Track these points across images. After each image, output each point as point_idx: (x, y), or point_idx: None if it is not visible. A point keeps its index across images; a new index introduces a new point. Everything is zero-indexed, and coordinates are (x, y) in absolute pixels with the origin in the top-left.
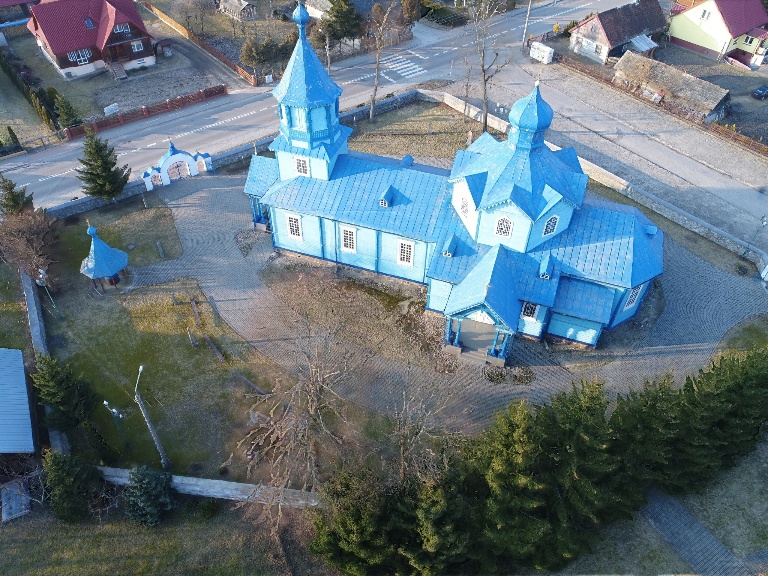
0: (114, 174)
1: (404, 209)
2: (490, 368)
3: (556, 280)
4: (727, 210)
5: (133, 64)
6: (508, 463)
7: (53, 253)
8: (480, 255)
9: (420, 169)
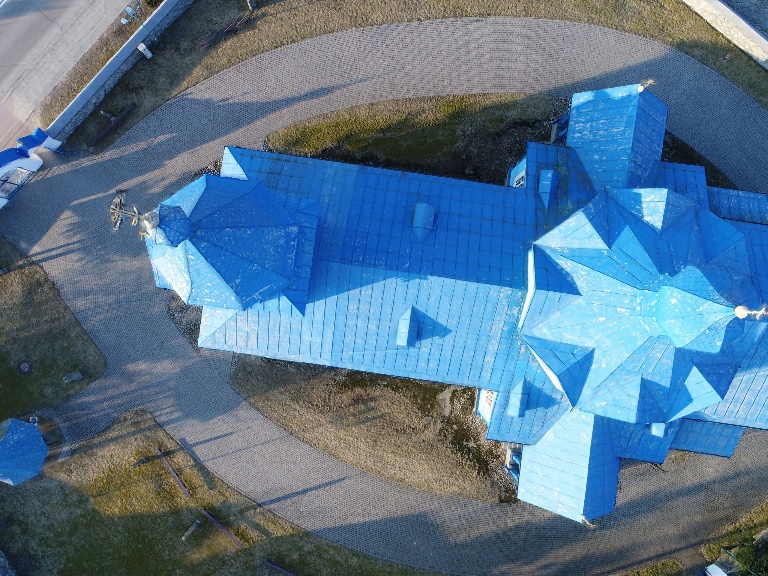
0: None
1: (440, 344)
2: None
3: (673, 431)
4: None
5: None
6: None
7: None
8: (564, 406)
9: (454, 248)
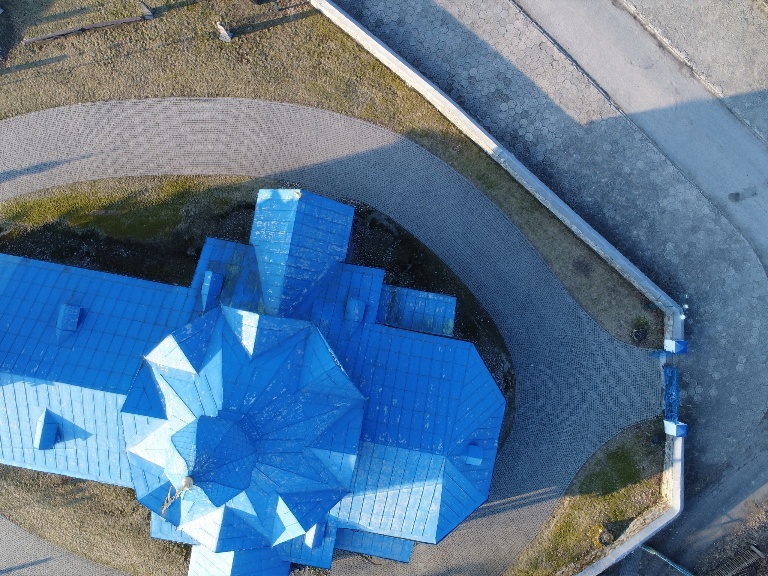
0: None
1: (84, 446)
2: None
3: (331, 539)
4: (658, 179)
5: None
6: None
7: None
8: None
9: (91, 352)
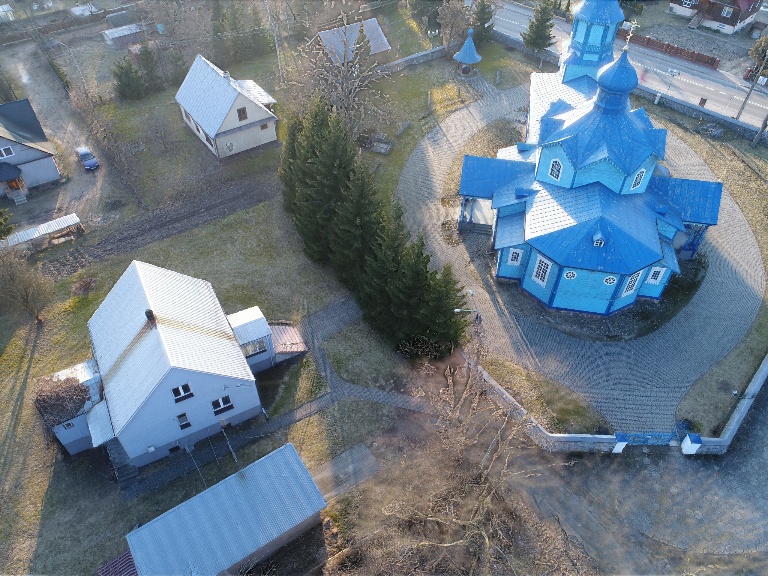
0: (544, 36)
1: None
2: (454, 223)
3: (517, 201)
4: None
5: (714, 24)
6: (311, 134)
7: (479, 51)
8: None
9: None
